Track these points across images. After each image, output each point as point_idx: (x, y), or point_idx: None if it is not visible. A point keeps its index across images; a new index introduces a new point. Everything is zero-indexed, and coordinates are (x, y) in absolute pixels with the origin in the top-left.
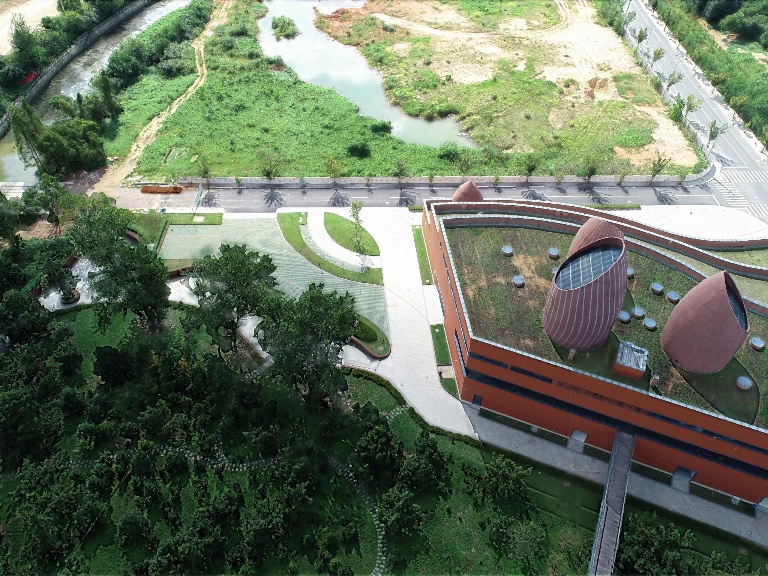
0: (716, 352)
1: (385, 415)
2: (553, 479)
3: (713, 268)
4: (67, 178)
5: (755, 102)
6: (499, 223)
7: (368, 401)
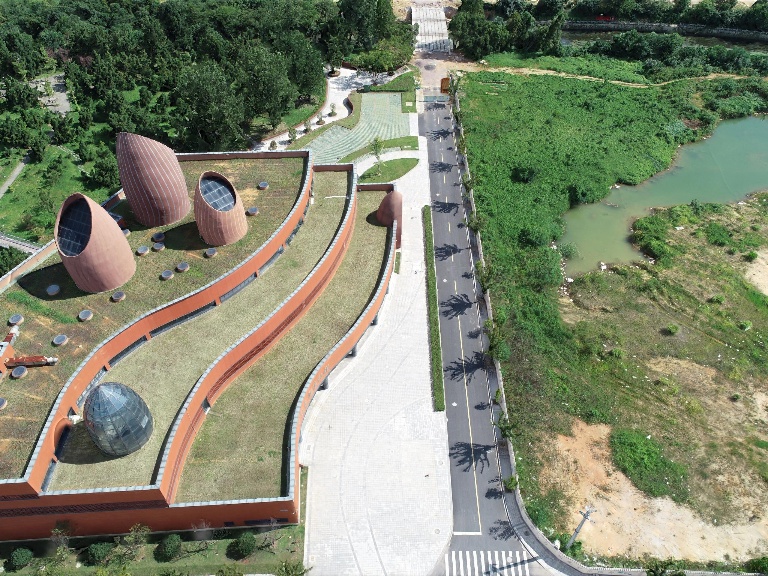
0: None
1: None
2: None
3: None
4: (458, 52)
5: None
6: None
7: None
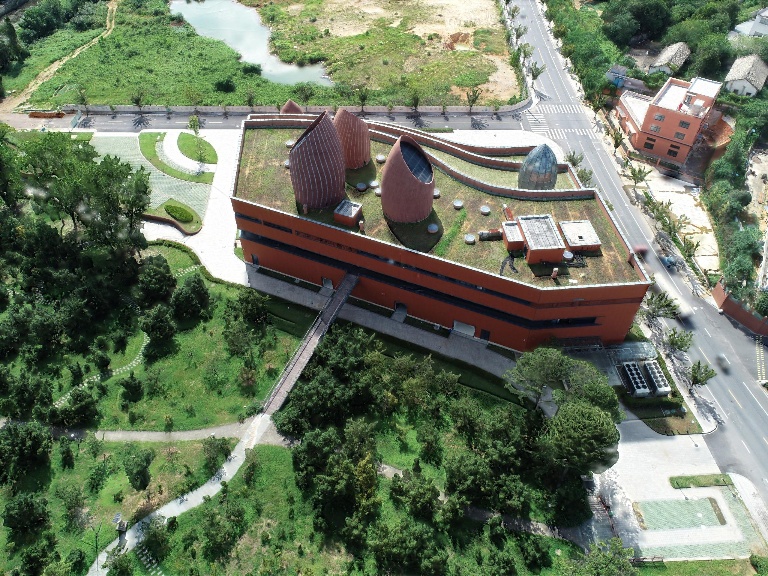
0: (404, 201)
1: (180, 271)
2: (298, 312)
3: (464, 161)
4: None
5: (581, 49)
6: (293, 126)
7: (159, 254)
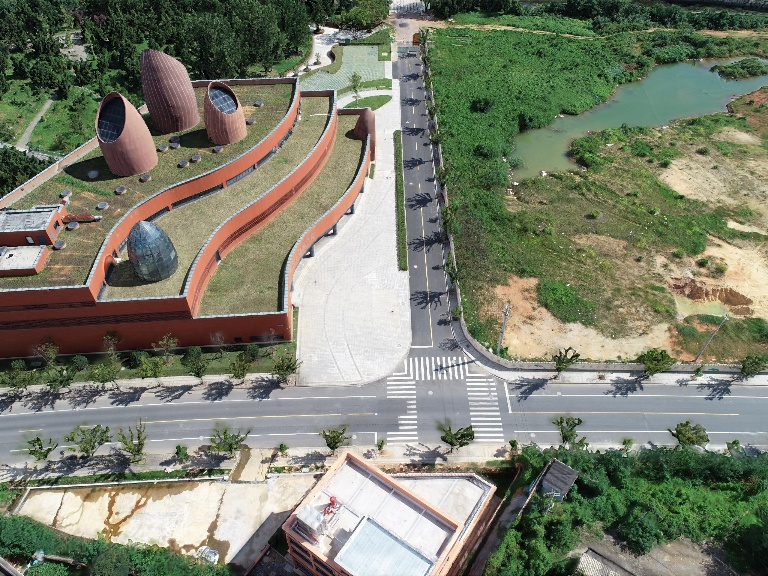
0: None
1: None
2: None
3: None
4: (429, 13)
5: None
6: None
7: None
